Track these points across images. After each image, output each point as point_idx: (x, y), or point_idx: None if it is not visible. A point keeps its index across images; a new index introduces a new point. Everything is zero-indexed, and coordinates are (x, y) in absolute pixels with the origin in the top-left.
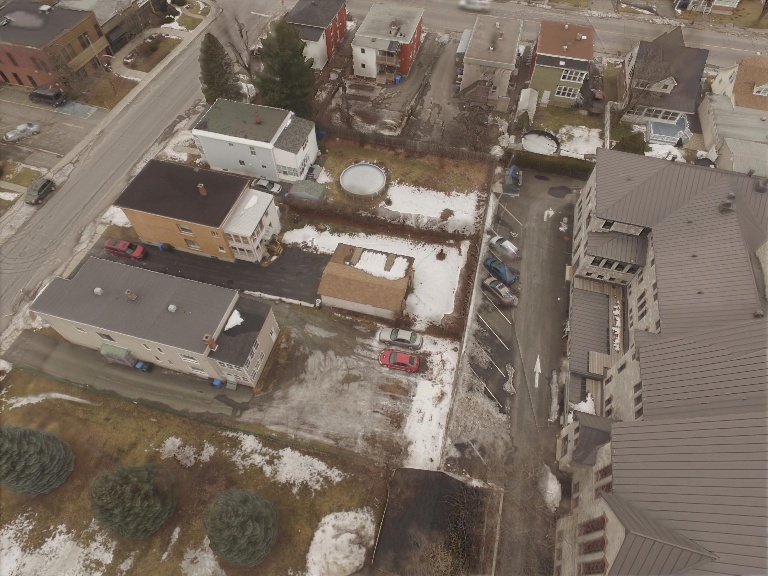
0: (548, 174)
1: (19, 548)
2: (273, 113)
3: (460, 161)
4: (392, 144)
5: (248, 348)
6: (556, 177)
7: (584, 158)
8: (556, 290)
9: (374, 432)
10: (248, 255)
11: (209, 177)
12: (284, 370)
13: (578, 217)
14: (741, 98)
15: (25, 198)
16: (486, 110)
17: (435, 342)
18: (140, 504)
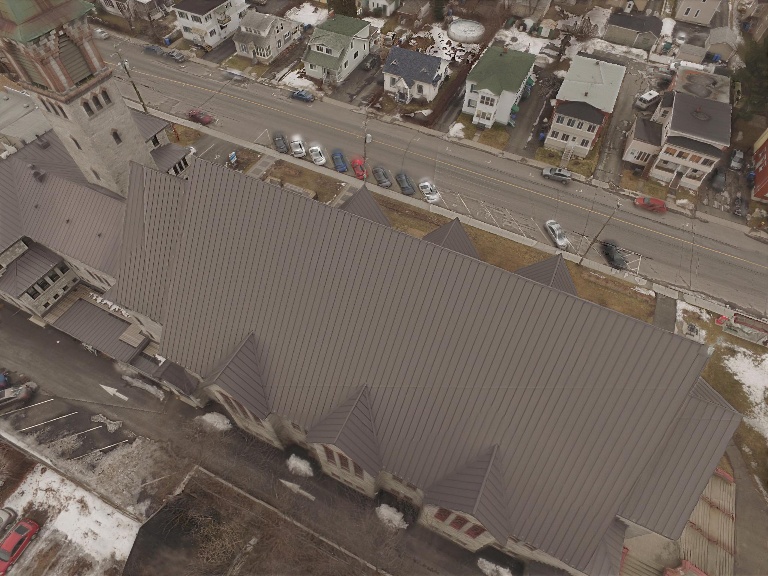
0: None
1: None
2: None
3: None
4: None
5: None
6: None
7: None
8: (47, 341)
9: None
10: None
11: None
12: None
13: None
14: None
15: None
16: None
17: (21, 493)
18: None
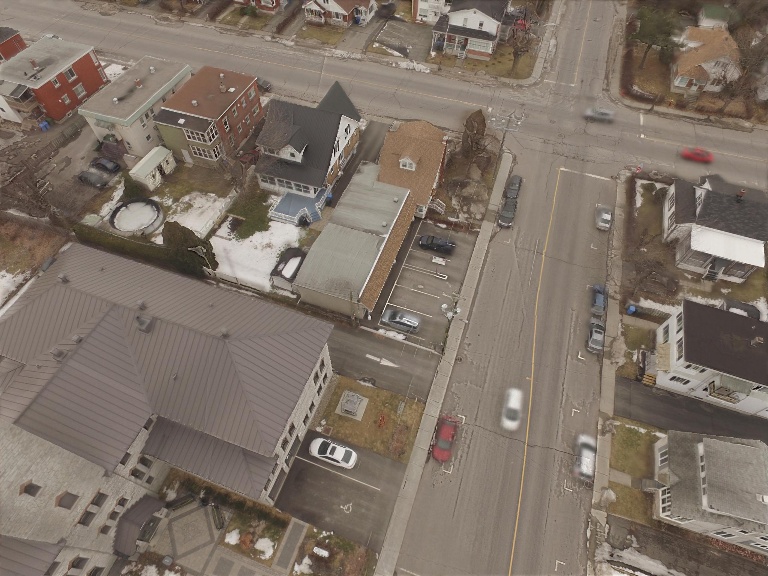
0: (121, 255)
1: None
2: None
3: (39, 232)
4: None
5: None
6: None
7: None
8: None
9: None
10: None
11: None
12: None
13: None
14: (386, 172)
15: None
16: (110, 169)
17: None
18: None
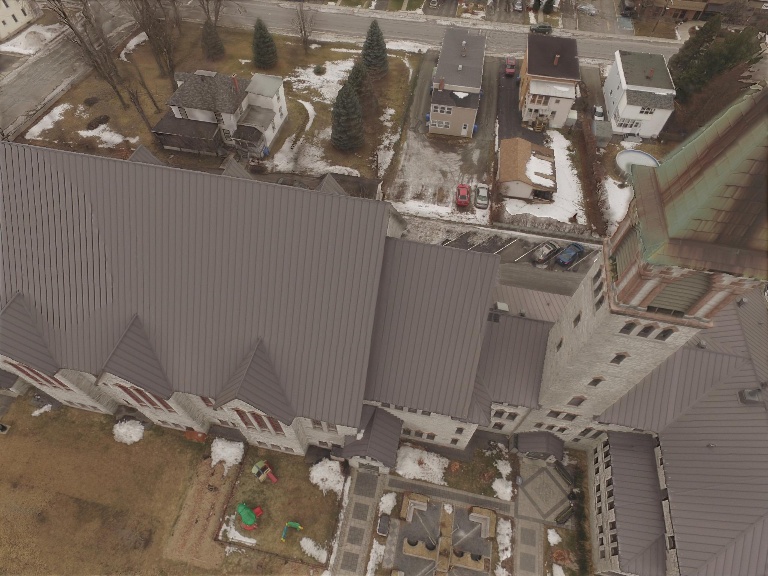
0: None
1: (340, 79)
2: (665, 82)
3: None
4: None
5: (444, 103)
6: None
7: None
8: None
9: (409, 186)
10: (524, 110)
11: (573, 64)
12: (443, 144)
13: None
14: None
15: (533, 25)
16: None
17: (485, 216)
18: (355, 90)
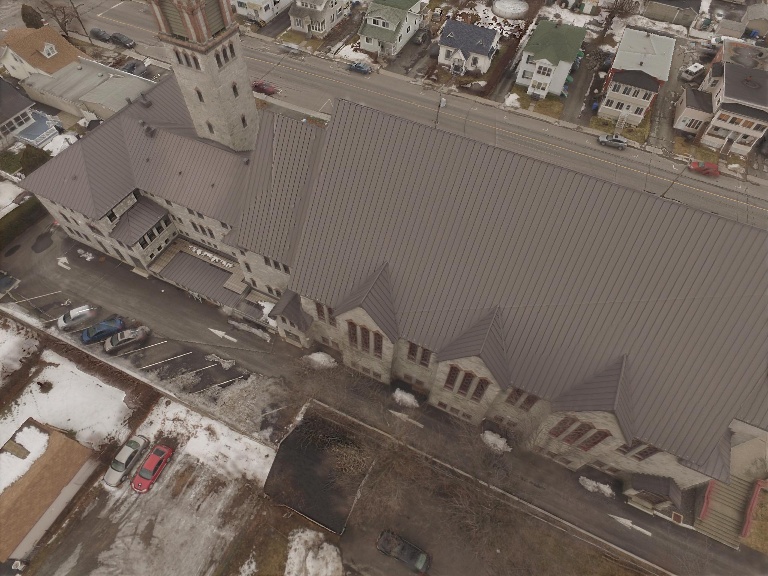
0: (12, 243)
1: None
2: None
3: None
4: None
5: None
6: (22, 238)
7: (17, 204)
8: (152, 290)
9: (219, 514)
10: None
11: None
12: None
13: (85, 239)
14: (45, 67)
15: None
16: None
17: (149, 423)
18: None
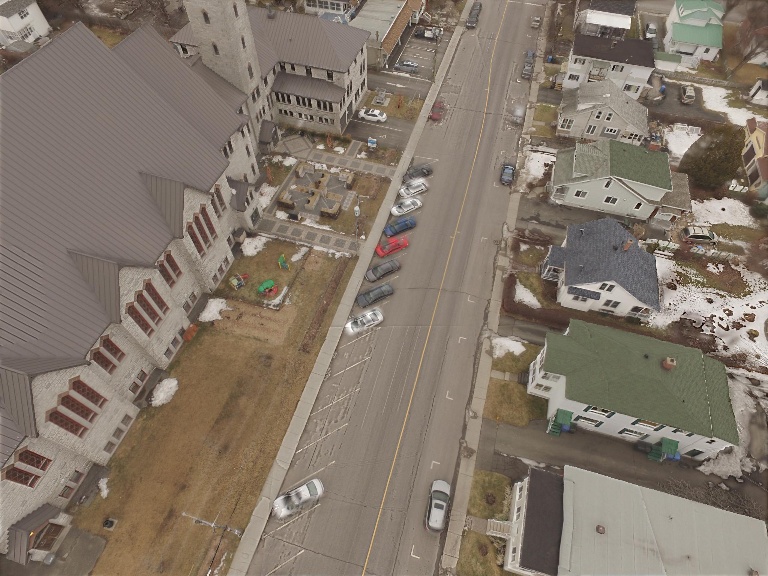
0: None
1: None
2: None
3: None
4: (112, 25)
5: None
6: None
7: None
8: None
9: None
10: None
11: None
12: None
13: None
14: None
15: None
16: None
17: None
18: None
